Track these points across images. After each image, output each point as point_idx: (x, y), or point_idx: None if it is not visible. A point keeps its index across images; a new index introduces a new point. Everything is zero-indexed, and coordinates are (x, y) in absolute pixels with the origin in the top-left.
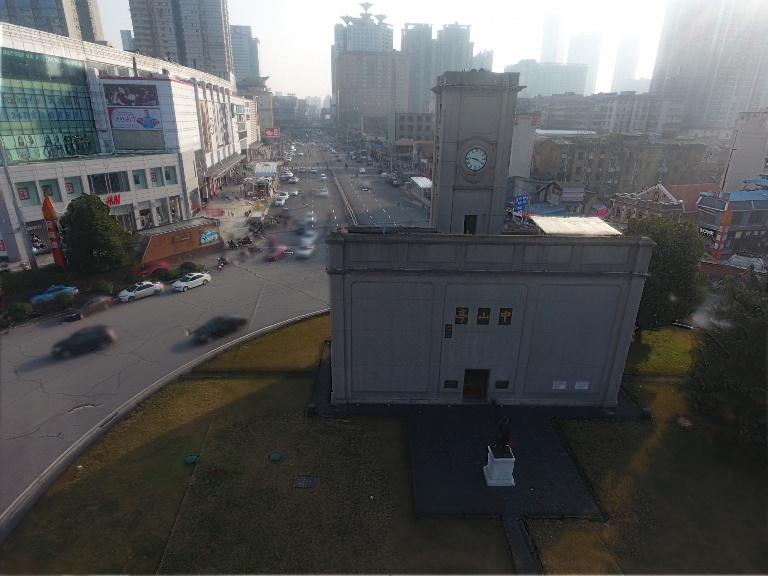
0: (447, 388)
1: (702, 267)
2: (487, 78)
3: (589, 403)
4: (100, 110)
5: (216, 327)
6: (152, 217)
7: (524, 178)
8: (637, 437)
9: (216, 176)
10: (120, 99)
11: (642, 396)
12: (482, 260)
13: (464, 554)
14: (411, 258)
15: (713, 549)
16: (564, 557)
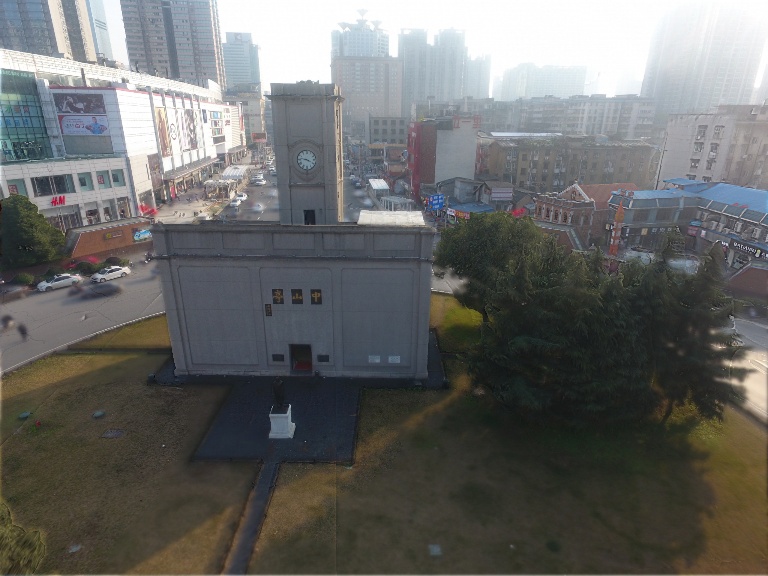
0: (275, 361)
1: None
2: (307, 89)
3: (403, 375)
4: (51, 118)
5: (112, 313)
6: (100, 217)
7: (463, 179)
8: (426, 402)
9: (174, 179)
10: (69, 107)
11: (457, 370)
12: (288, 247)
13: (213, 487)
14: (226, 245)
15: (425, 486)
16: (296, 490)
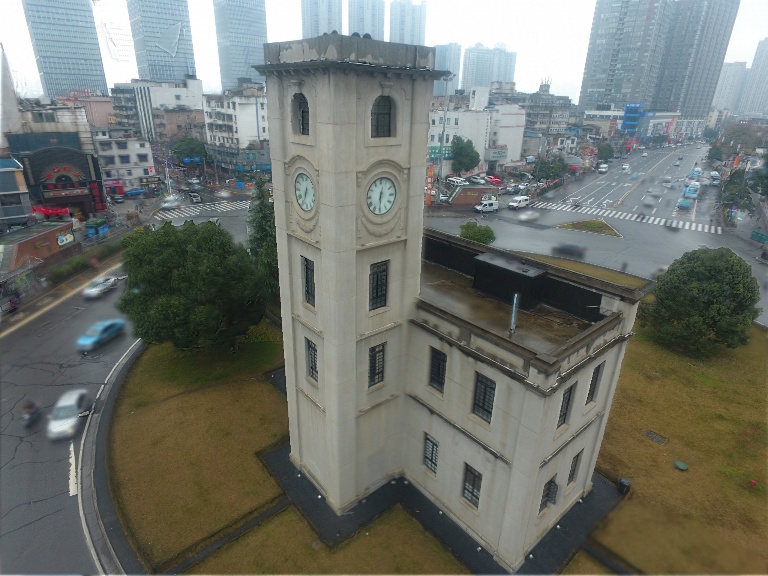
0: None
1: None
2: None
3: None
4: None
5: None
6: None
7: None
8: None
9: None
10: None
11: None
12: None
13: None
14: None
15: None
16: None
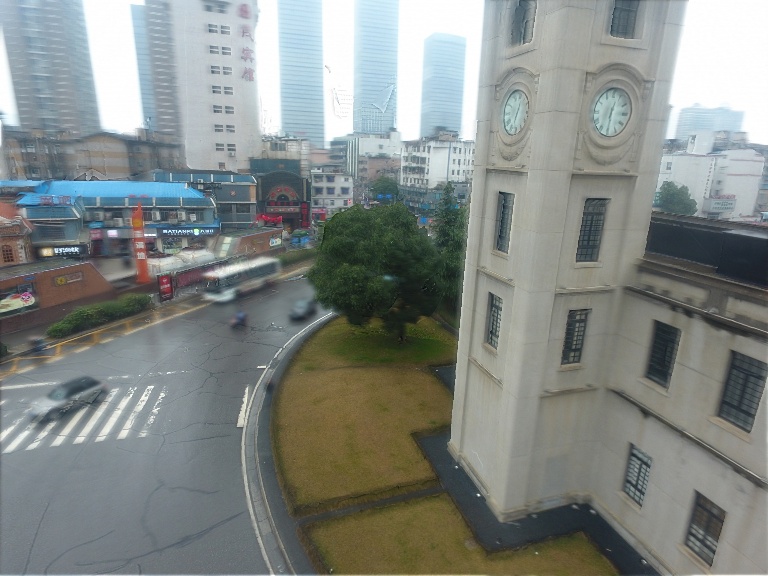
0: None
1: (179, 278)
2: None
3: None
4: None
5: None
6: None
7: None
8: None
9: None
10: None
11: None
12: None
13: None
14: None
15: None
16: None
